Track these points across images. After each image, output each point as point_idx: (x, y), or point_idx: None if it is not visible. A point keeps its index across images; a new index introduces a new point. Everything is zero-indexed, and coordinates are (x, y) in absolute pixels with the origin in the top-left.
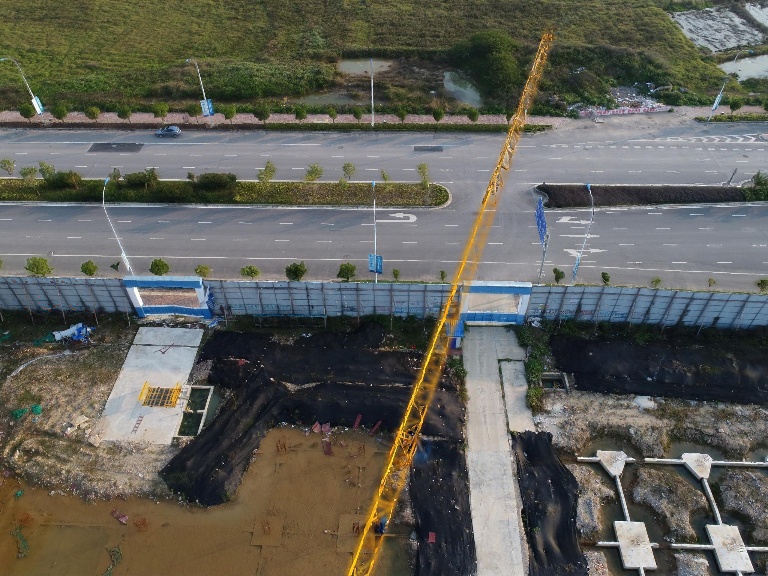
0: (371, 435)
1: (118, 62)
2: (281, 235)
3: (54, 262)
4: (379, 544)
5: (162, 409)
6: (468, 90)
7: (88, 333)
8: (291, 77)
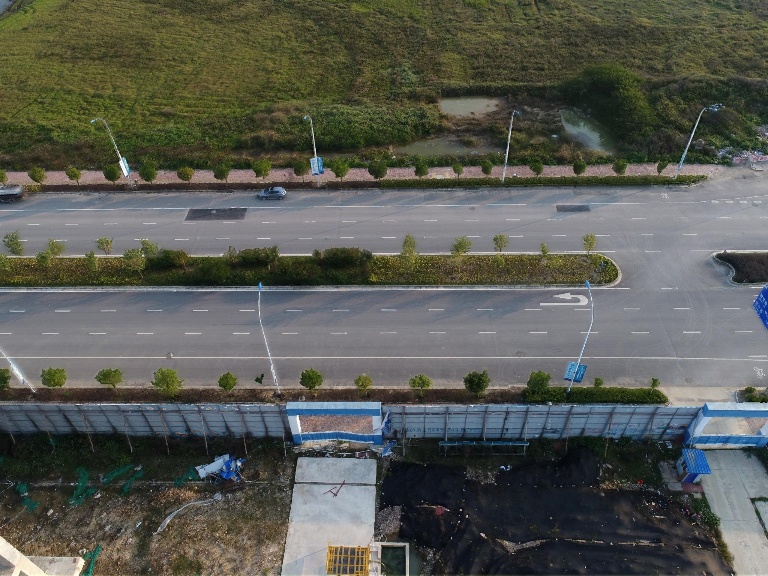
0: None
1: (195, 107)
2: (435, 325)
3: (176, 367)
4: None
5: None
6: (583, 129)
7: (239, 468)
8: (393, 122)
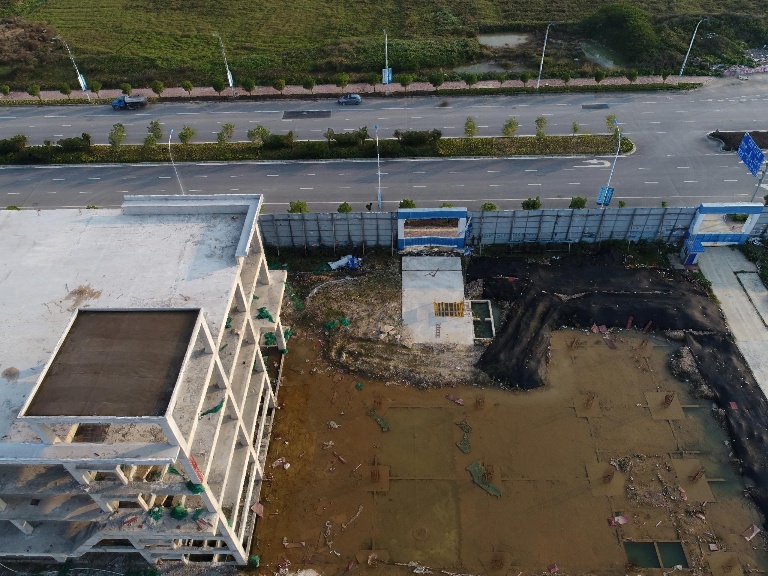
0: (644, 333)
1: (271, 43)
2: (493, 181)
3: None
4: (687, 413)
5: (454, 318)
6: None
7: (360, 262)
8: (442, 50)
